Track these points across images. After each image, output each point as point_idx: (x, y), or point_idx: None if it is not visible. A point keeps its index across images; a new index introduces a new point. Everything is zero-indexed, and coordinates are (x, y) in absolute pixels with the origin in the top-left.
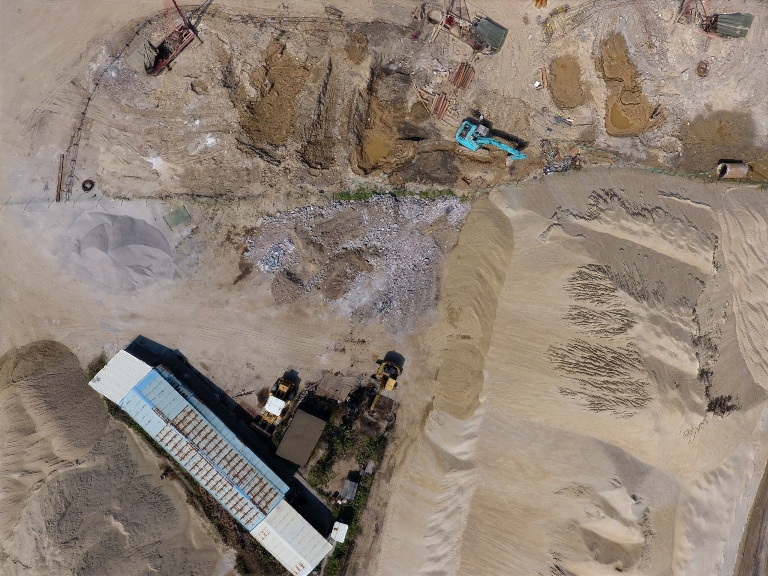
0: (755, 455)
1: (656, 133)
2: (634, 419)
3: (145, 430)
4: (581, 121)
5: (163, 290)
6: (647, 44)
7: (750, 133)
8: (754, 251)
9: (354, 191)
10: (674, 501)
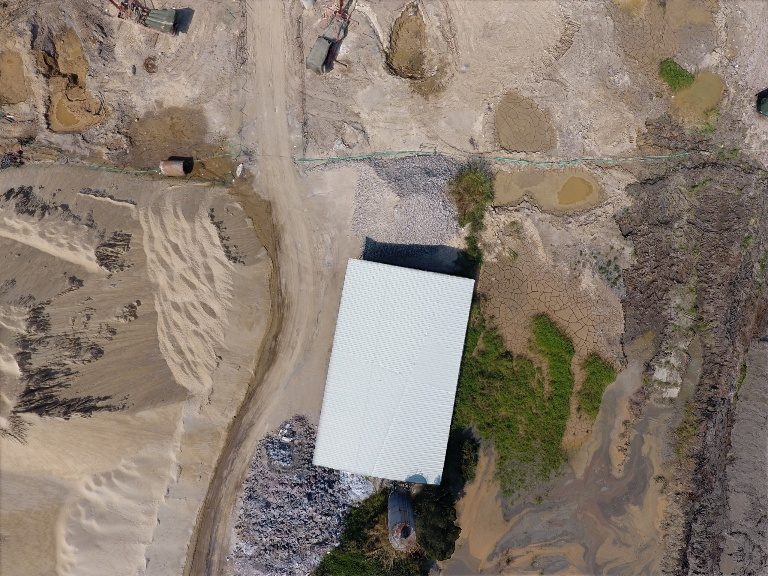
0: (178, 457)
1: (99, 130)
2: None
3: None
4: (23, 117)
5: None
6: (91, 39)
7: (202, 130)
8: (178, 250)
9: None
10: (55, 503)
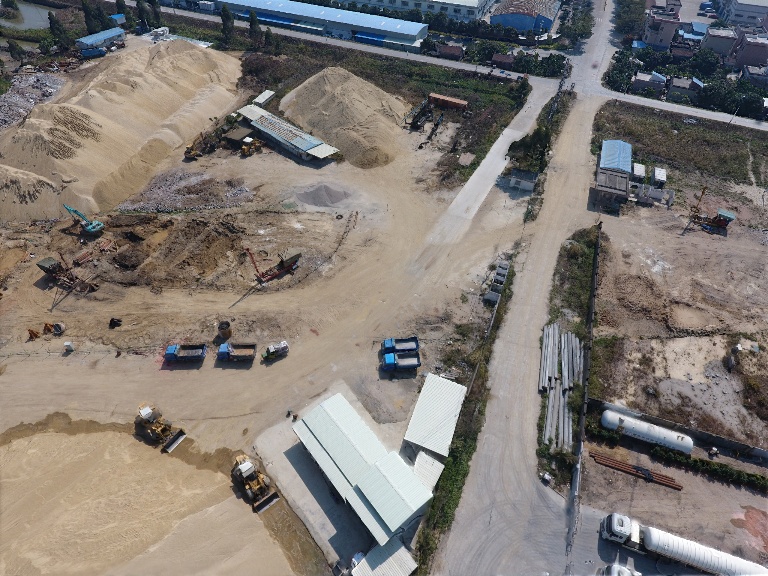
0: None
1: None
2: None
3: None
4: None
5: None
6: None
7: None
8: None
9: None
10: None
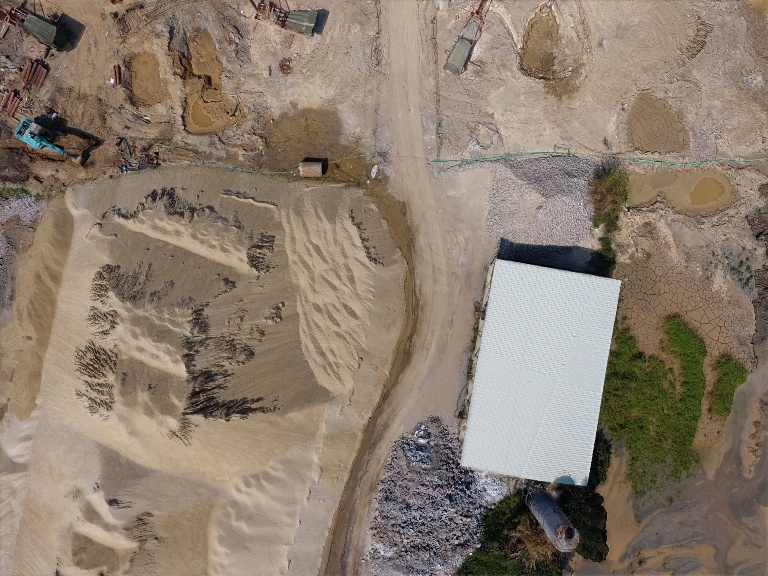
0: (320, 458)
1: (236, 131)
2: (110, 422)
3: None
4: (159, 119)
5: None
6: (227, 41)
7: (336, 131)
8: (319, 251)
9: None
10: (207, 505)
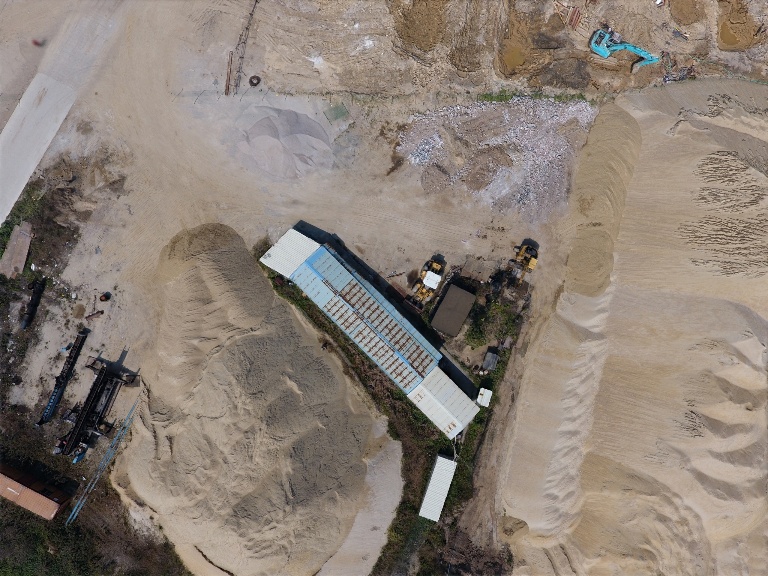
0: None
1: (760, 49)
2: (765, 277)
3: (314, 301)
4: (696, 36)
5: (323, 179)
6: None
7: None
8: None
9: (496, 93)
10: None
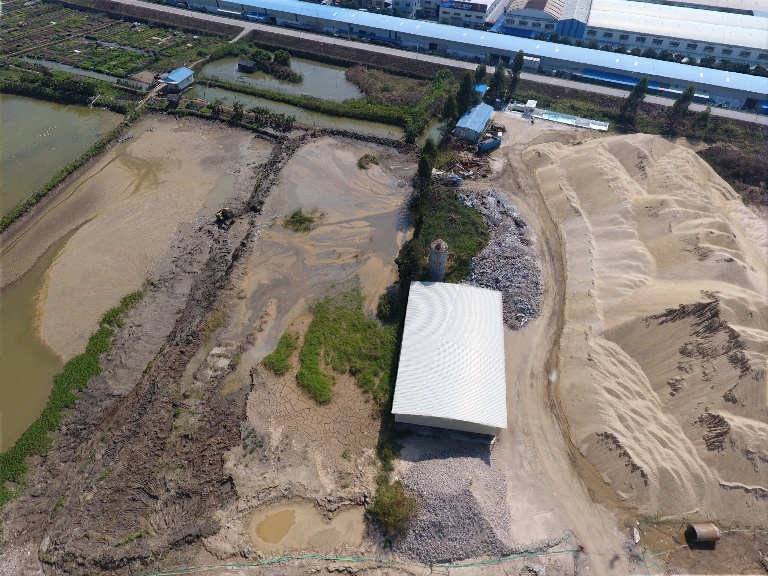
0: None
1: None
2: None
3: None
4: None
5: None
6: None
7: None
8: (661, 442)
9: None
10: None
